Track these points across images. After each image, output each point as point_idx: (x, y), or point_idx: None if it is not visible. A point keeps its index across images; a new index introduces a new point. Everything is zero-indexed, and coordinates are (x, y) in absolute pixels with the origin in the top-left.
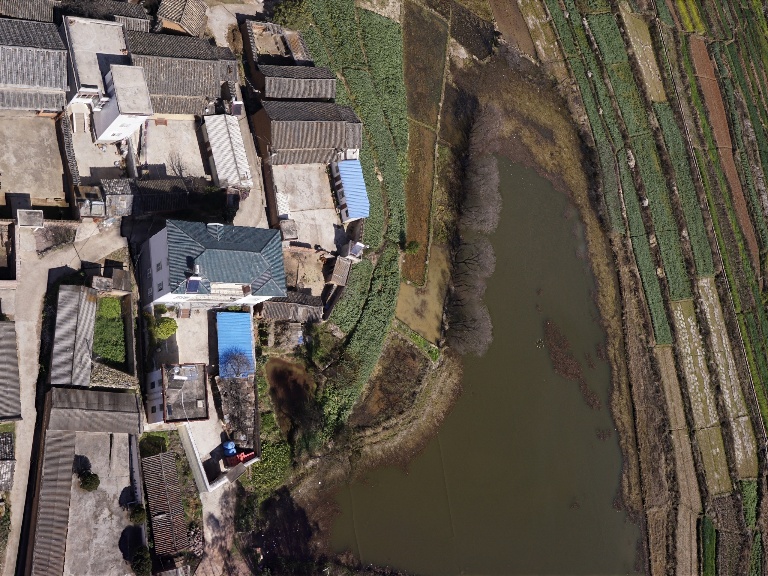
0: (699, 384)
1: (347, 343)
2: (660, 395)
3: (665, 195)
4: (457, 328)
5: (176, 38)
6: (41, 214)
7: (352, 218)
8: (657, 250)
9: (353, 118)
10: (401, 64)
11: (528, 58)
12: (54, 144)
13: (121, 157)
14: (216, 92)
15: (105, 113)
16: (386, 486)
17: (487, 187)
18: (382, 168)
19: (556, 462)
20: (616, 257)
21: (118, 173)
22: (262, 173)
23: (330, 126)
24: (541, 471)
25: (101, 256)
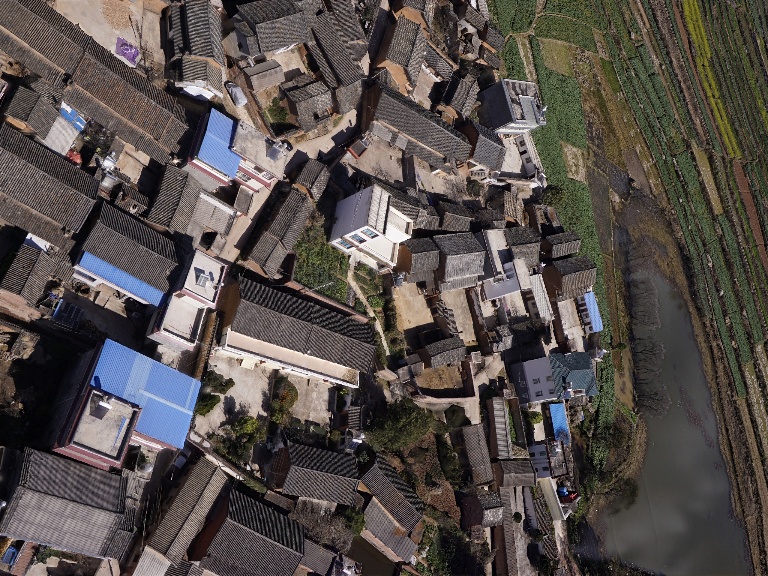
0: (763, 424)
1: (597, 416)
2: (743, 435)
3: (730, 285)
4: (645, 400)
5: (516, 229)
6: (480, 354)
7: None
8: (731, 328)
9: (591, 264)
10: None
11: None
12: (467, 305)
13: (494, 309)
14: (537, 261)
15: (500, 286)
16: (624, 510)
17: (652, 299)
18: (596, 292)
19: (698, 488)
20: (709, 336)
21: (494, 319)
22: None
23: (585, 273)
24: (692, 494)
25: (496, 374)
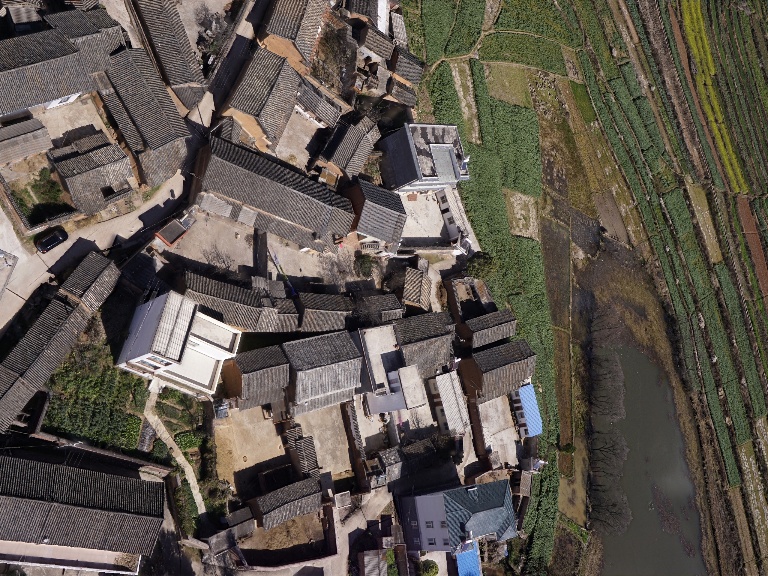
0: (761, 517)
1: (530, 543)
2: (735, 533)
3: (726, 348)
4: (600, 512)
5: (419, 318)
6: (349, 494)
7: (531, 436)
8: (725, 401)
9: (529, 351)
10: (544, 279)
11: (624, 245)
12: (341, 423)
13: (383, 423)
14: (447, 358)
15: (384, 400)
16: None
17: (615, 383)
18: (541, 380)
19: None
20: (696, 413)
21: (382, 437)
22: (468, 409)
23: (518, 365)
24: None
25: (378, 513)
